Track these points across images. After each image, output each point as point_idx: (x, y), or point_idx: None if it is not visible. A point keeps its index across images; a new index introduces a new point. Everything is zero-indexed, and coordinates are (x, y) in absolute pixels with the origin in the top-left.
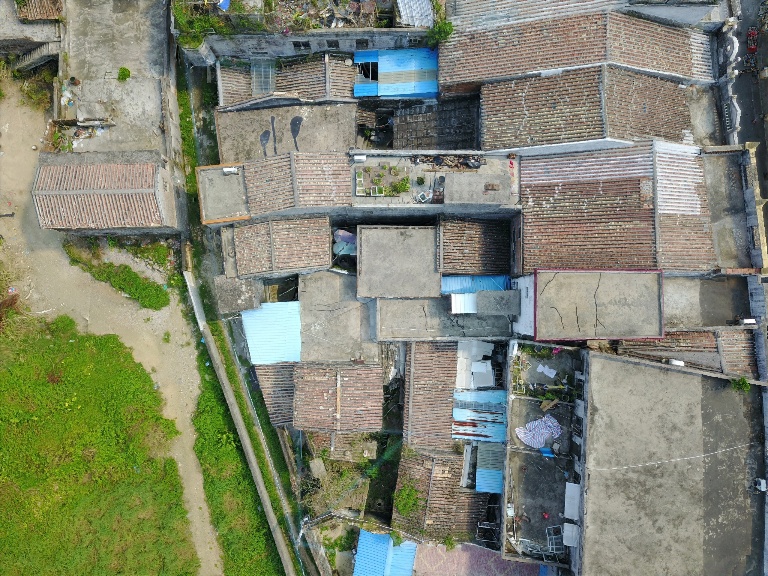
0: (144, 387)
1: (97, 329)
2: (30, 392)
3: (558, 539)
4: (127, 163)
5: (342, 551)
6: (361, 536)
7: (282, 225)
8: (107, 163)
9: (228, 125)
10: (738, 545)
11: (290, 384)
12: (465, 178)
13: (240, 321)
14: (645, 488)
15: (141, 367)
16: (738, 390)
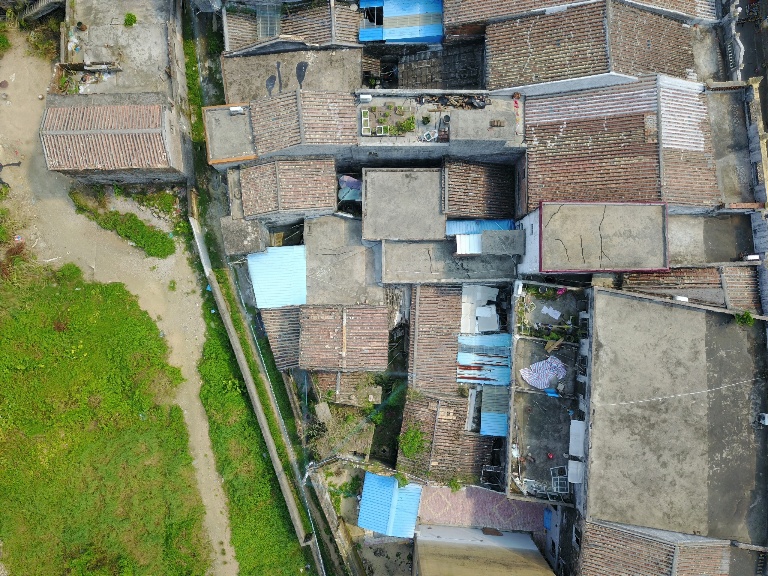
0: (150, 335)
1: (103, 277)
2: (36, 339)
3: (563, 479)
4: (134, 105)
5: (347, 497)
6: (366, 480)
7: (288, 165)
8: (114, 105)
9: (234, 70)
10: (742, 480)
11: (296, 327)
12: (470, 115)
13: (245, 269)
14: (650, 423)
15: (147, 315)
16: (742, 326)
